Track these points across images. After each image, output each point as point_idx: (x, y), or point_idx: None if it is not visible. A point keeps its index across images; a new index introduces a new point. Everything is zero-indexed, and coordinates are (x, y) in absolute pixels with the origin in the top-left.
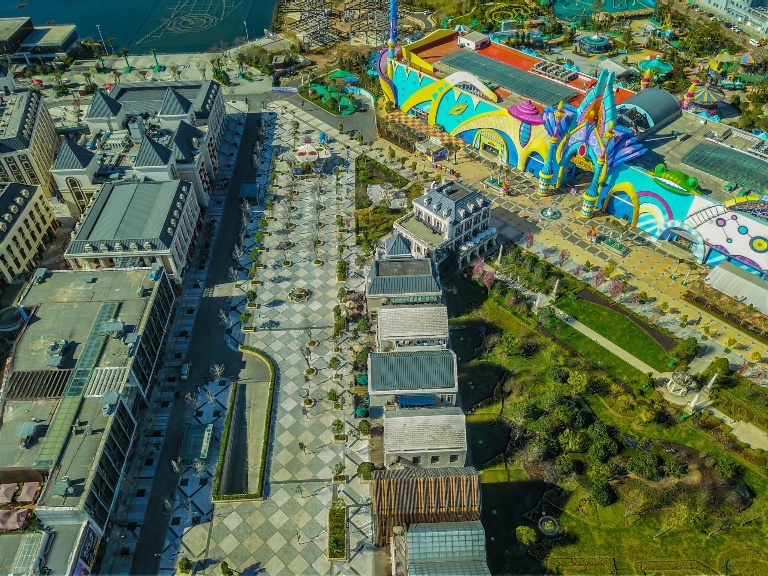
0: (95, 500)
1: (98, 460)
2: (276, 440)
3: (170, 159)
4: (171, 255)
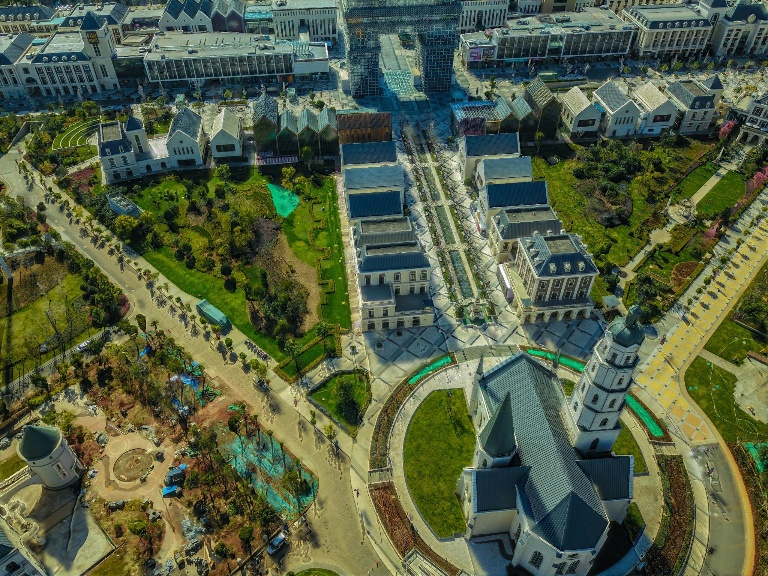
0: (505, 45)
1: (519, 36)
2: (560, 93)
3: (719, 8)
4: (648, 34)
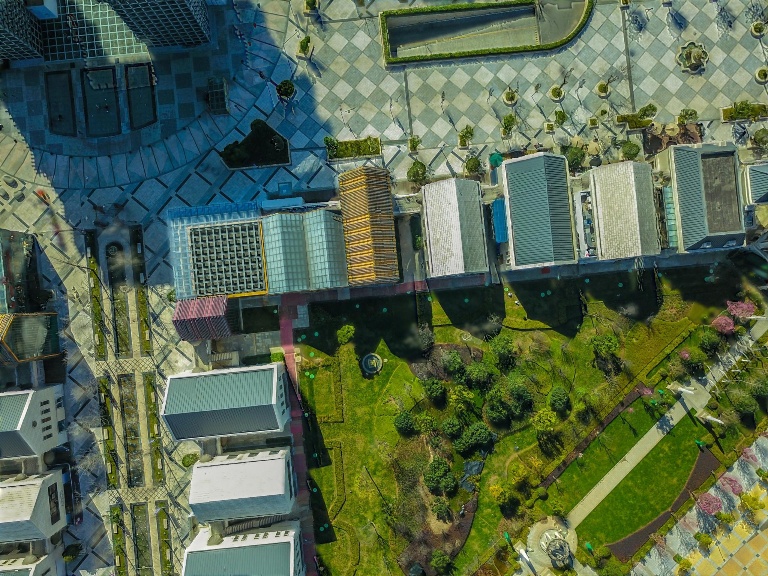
0: None
1: None
2: (457, 67)
3: None
4: None
